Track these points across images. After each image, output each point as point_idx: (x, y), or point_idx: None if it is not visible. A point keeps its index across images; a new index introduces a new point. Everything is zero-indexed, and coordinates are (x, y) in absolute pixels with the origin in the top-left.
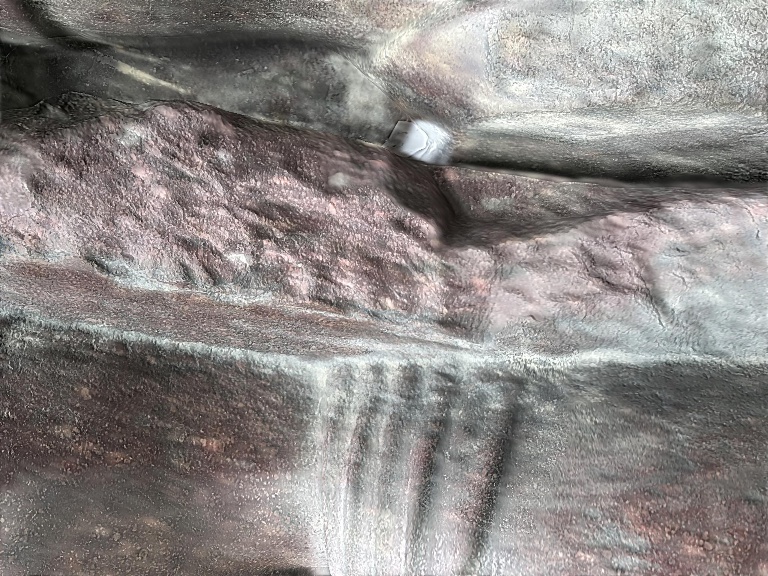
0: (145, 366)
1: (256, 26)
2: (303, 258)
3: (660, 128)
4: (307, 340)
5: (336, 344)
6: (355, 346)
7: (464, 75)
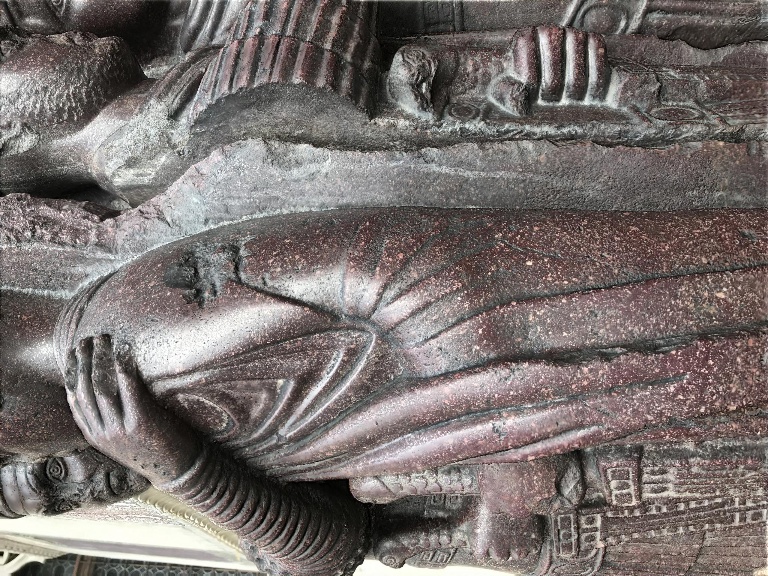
0: (5, 295)
1: (58, 176)
2: (49, 231)
3: (159, 163)
4: (62, 273)
5: (73, 272)
6: (80, 272)
7: (103, 165)
